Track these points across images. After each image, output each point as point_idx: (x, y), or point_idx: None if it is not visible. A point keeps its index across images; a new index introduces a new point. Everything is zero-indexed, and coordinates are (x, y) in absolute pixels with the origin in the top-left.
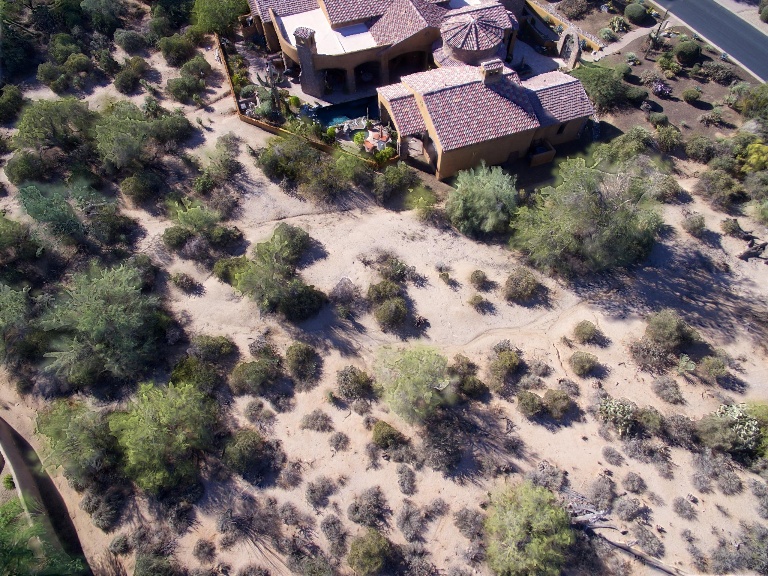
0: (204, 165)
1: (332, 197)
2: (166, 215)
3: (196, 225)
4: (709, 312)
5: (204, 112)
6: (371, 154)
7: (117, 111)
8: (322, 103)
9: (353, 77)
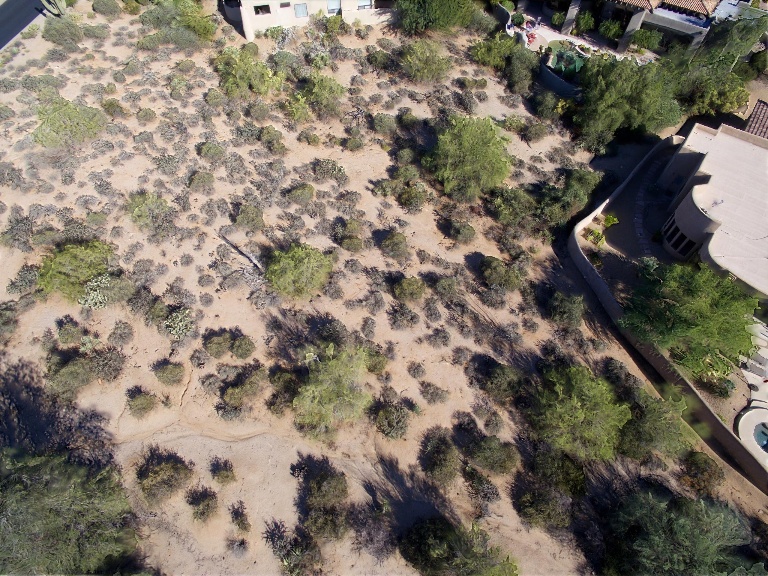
0: None
1: None
2: None
3: None
4: (12, 390)
5: None
6: None
7: None
8: None
9: None
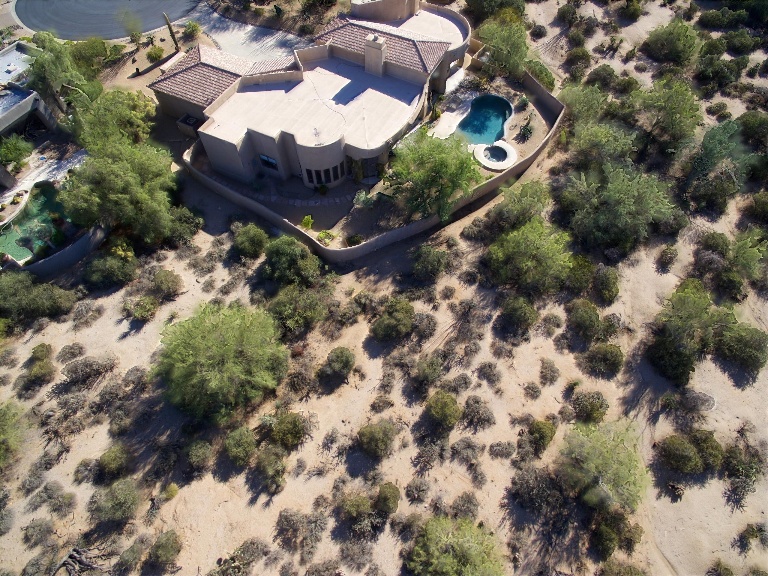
0: None
1: None
2: (741, 235)
3: (738, 257)
4: None
5: None
6: None
7: None
8: None
9: None
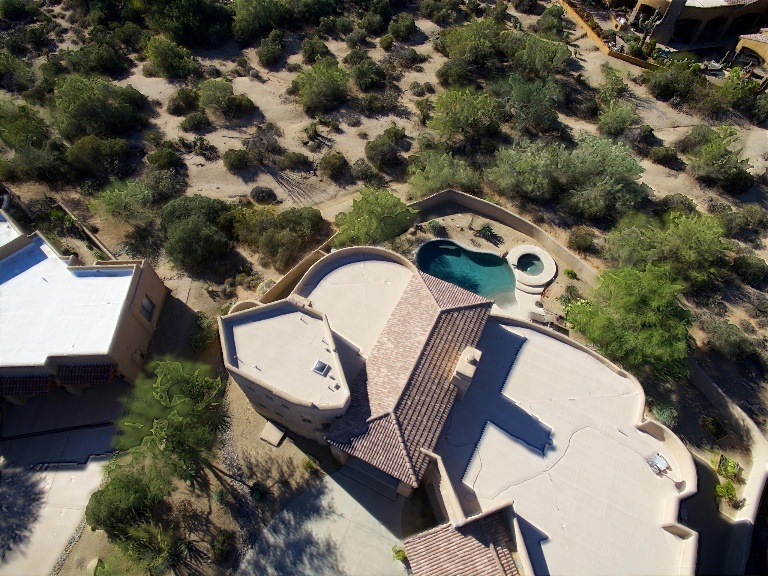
0: (592, 84)
1: (716, 114)
2: (578, 117)
3: (625, 121)
4: None
5: (571, 47)
6: (736, 87)
7: (513, 37)
8: (669, 49)
9: (702, 29)
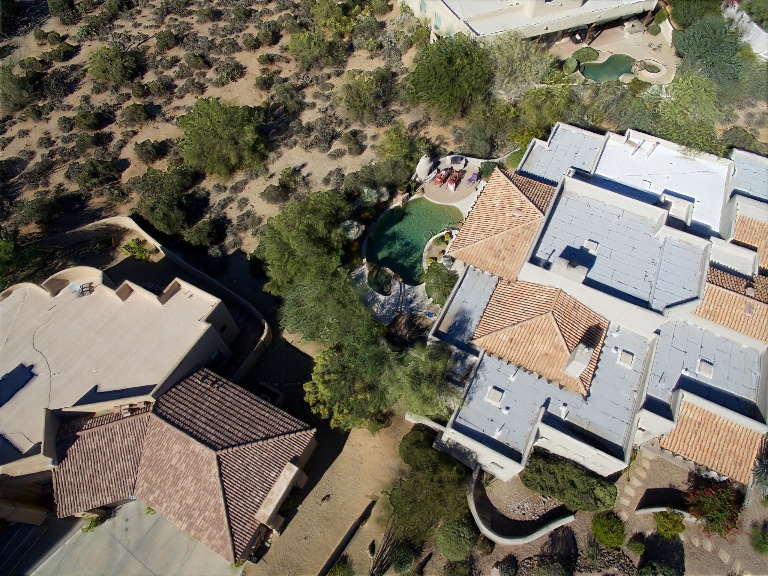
0: None
1: None
2: None
3: None
4: None
5: None
6: None
7: None
8: None
9: None
